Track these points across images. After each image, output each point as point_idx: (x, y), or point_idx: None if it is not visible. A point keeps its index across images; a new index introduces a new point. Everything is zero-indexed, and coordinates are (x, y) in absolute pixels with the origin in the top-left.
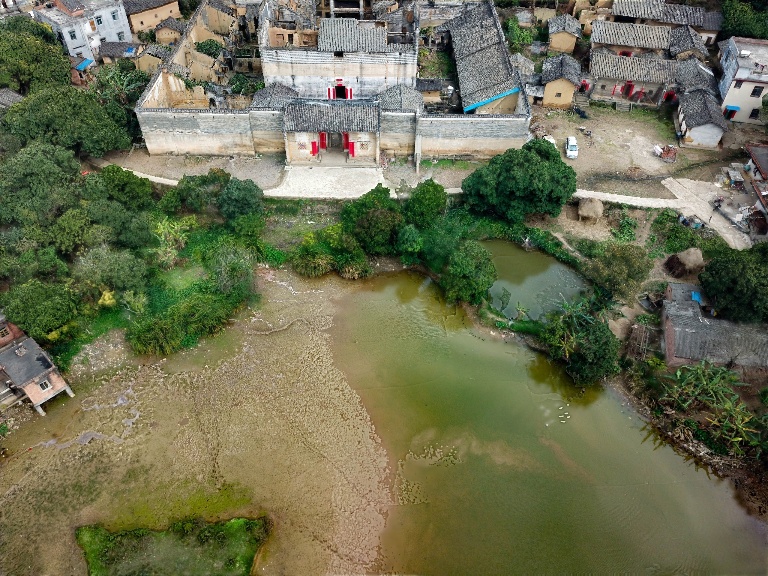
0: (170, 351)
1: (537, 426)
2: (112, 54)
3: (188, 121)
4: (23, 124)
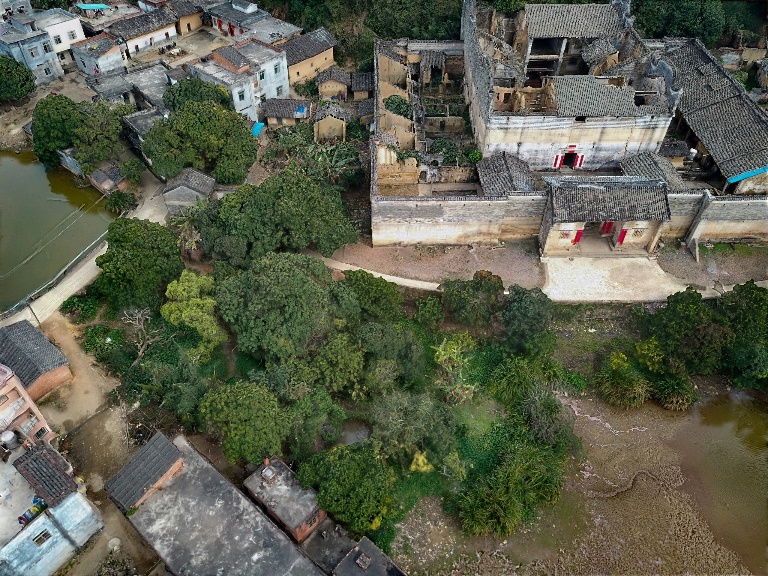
0: (512, 531)
1: None
2: (280, 114)
3: (432, 209)
4: (248, 223)
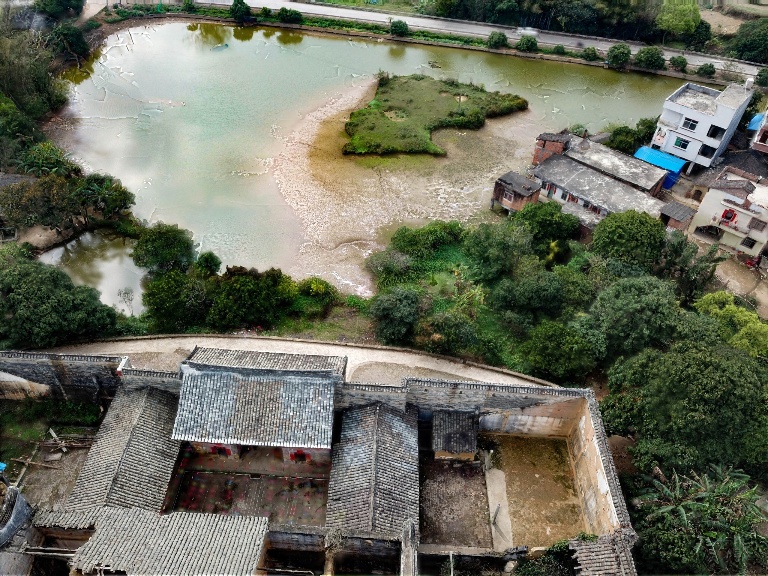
0: None
1: (169, 183)
2: None
3: None
4: None
